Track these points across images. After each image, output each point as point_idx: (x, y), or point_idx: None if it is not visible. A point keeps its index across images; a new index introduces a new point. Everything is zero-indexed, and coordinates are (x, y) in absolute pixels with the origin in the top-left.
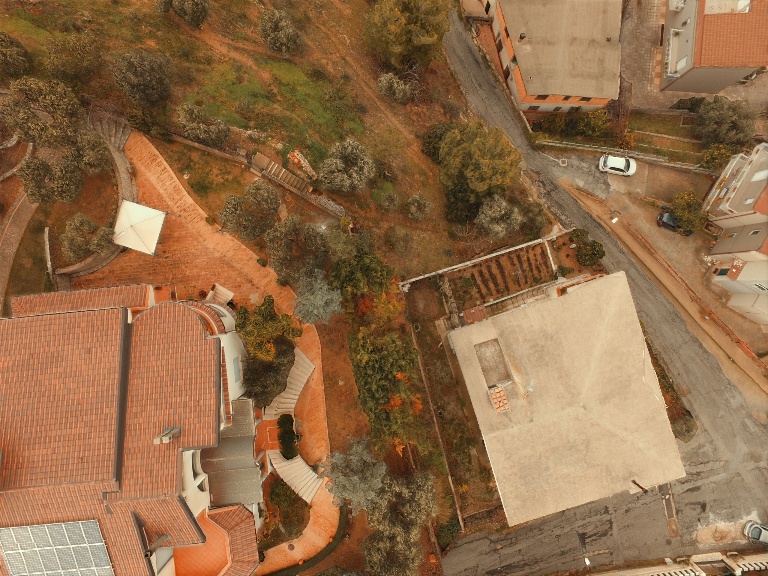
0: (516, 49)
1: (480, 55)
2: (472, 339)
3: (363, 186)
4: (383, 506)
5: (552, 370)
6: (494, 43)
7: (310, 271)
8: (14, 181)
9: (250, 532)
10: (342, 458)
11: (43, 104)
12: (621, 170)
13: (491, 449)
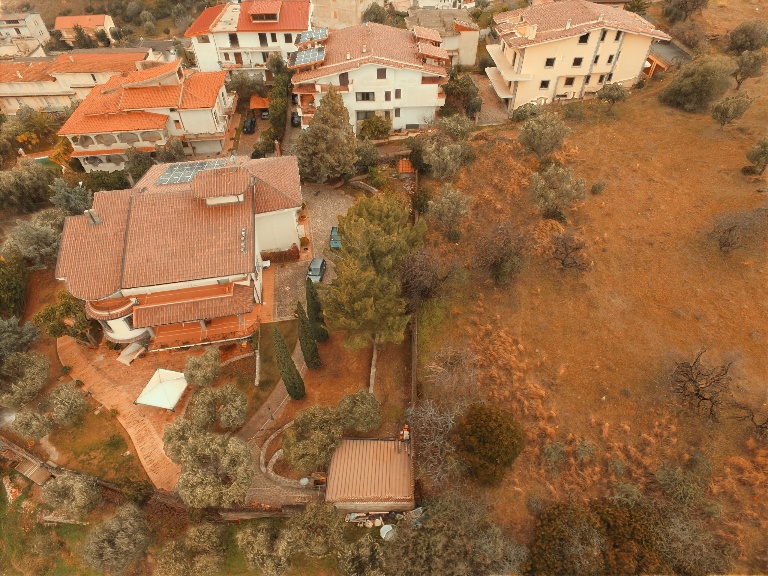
0: None
1: None
2: None
3: None
4: None
5: None
6: None
7: (6, 357)
8: (286, 423)
9: None
10: None
11: None
12: None
13: None
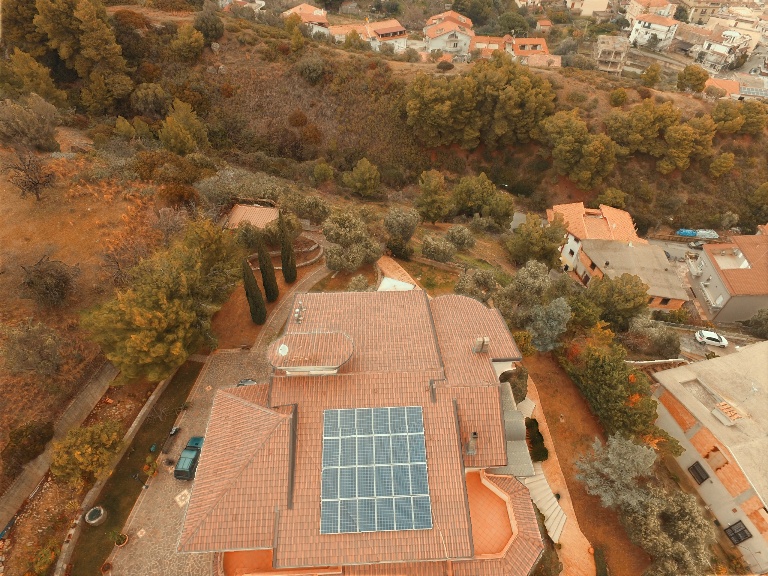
0: (604, 272)
1: (574, 283)
2: (675, 378)
3: (546, 290)
4: (655, 514)
5: (761, 398)
6: (580, 280)
7: None
8: (304, 269)
9: (528, 505)
10: (601, 447)
11: (347, 225)
12: (716, 340)
13: (742, 462)
